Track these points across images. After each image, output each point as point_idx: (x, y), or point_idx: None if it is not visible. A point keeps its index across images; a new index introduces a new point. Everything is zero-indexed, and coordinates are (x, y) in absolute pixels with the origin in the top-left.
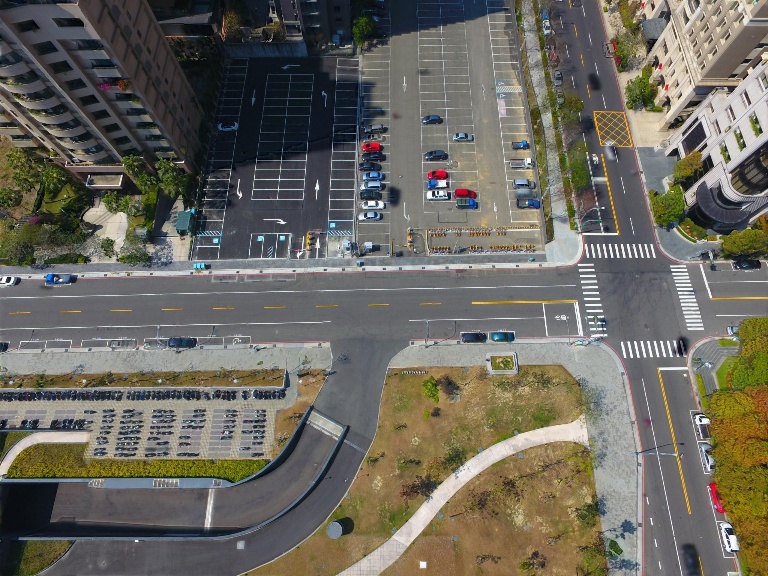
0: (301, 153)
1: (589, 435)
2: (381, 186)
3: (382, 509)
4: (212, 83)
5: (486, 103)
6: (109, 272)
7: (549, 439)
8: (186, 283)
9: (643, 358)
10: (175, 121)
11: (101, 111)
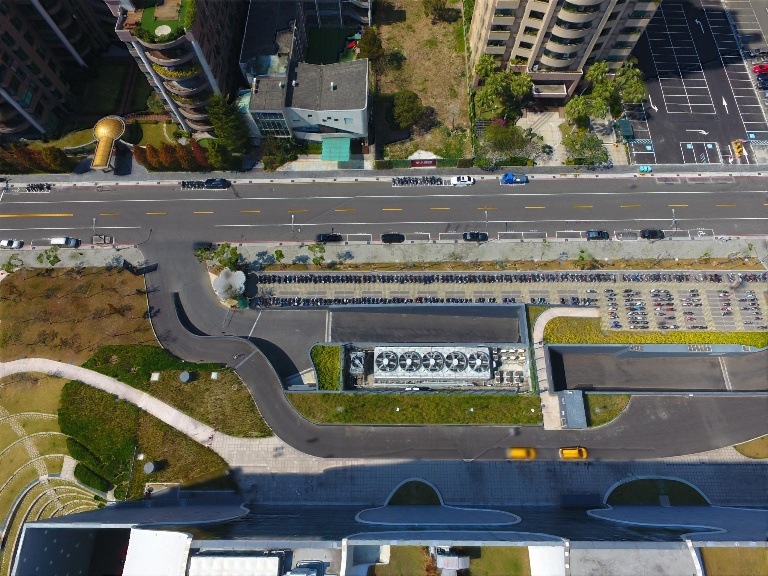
0: (698, 73)
1: None
2: None
3: None
4: None
5: None
6: (557, 174)
7: None
8: (634, 184)
9: None
10: None
11: (614, 13)
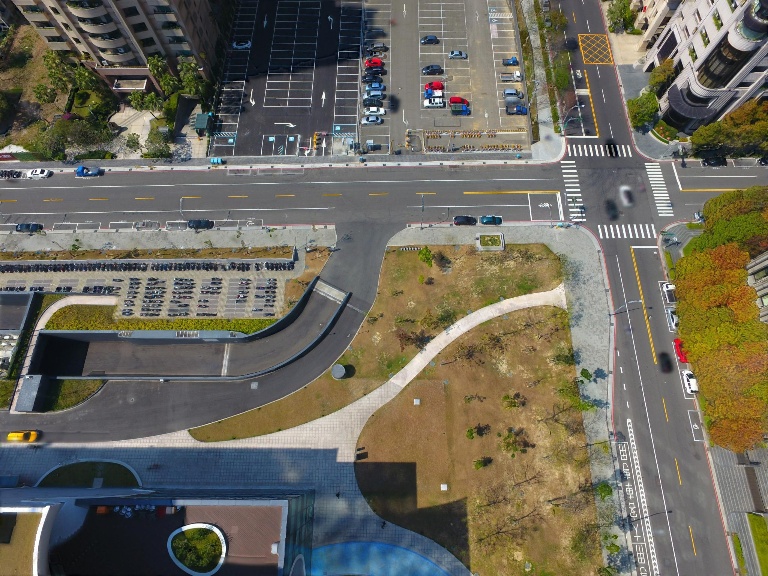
0: (309, 68)
1: (567, 300)
2: (382, 95)
3: (381, 358)
4: (227, 8)
5: (479, 27)
6: (134, 167)
7: (531, 304)
8: (204, 176)
9: (618, 238)
10: (195, 29)
11: (131, 8)
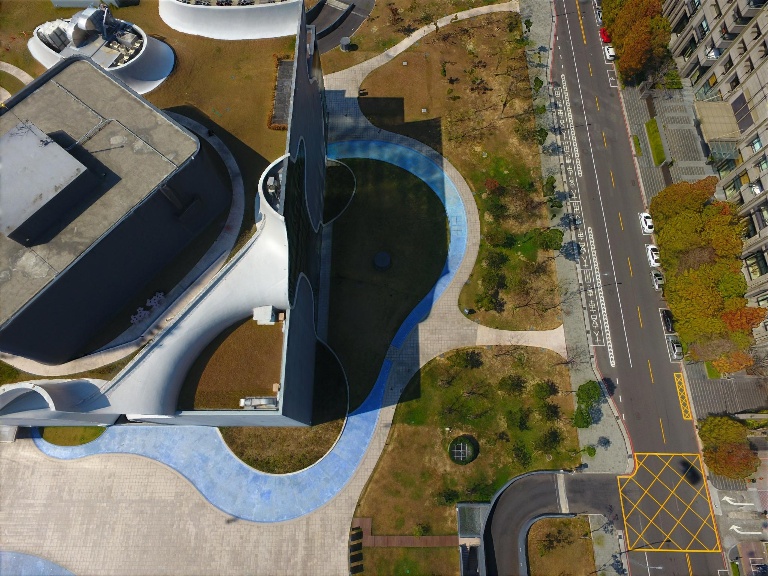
0: None
1: (520, 7)
2: None
3: (377, 40)
4: None
5: None
6: None
7: (493, 10)
8: None
9: None
10: None
11: None
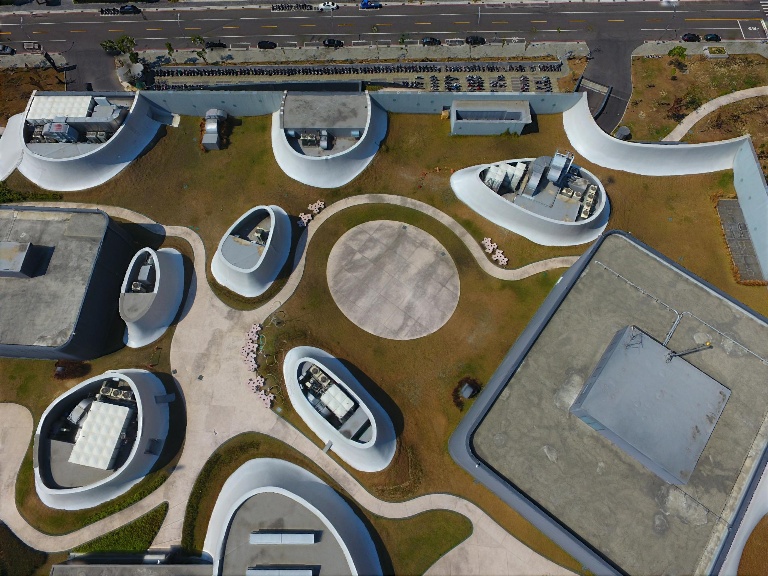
0: None
1: None
2: None
3: (649, 127)
4: None
5: None
6: (406, 2)
7: (758, 94)
8: (467, 8)
9: None
10: None
11: None
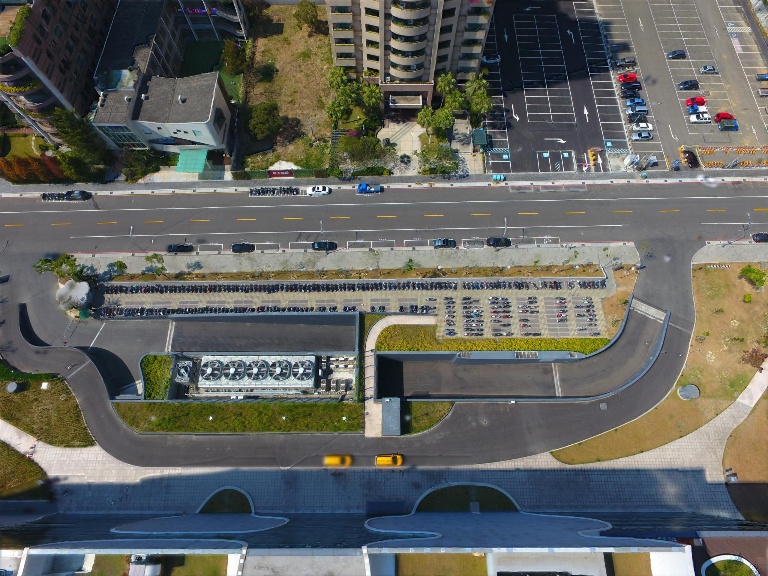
0: (563, 83)
1: None
2: (646, 111)
3: (721, 377)
4: None
5: (721, 41)
6: (413, 183)
7: None
8: (487, 193)
9: None
10: None
11: (447, 26)
